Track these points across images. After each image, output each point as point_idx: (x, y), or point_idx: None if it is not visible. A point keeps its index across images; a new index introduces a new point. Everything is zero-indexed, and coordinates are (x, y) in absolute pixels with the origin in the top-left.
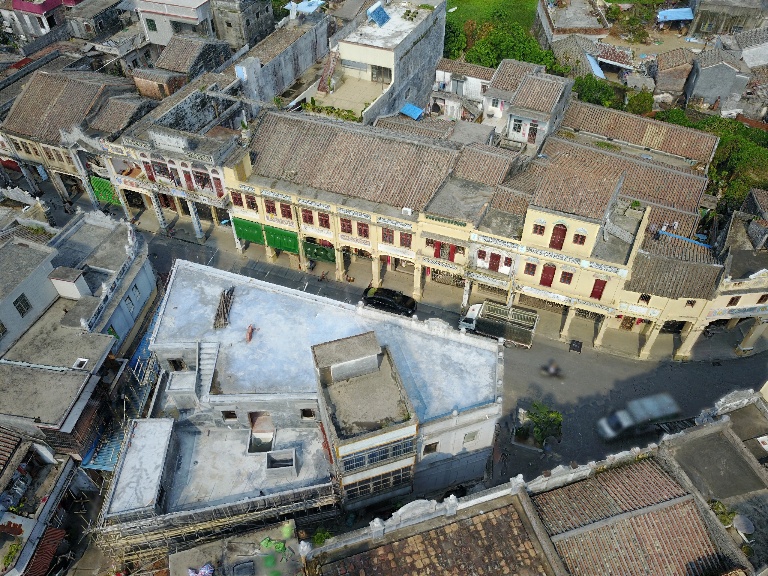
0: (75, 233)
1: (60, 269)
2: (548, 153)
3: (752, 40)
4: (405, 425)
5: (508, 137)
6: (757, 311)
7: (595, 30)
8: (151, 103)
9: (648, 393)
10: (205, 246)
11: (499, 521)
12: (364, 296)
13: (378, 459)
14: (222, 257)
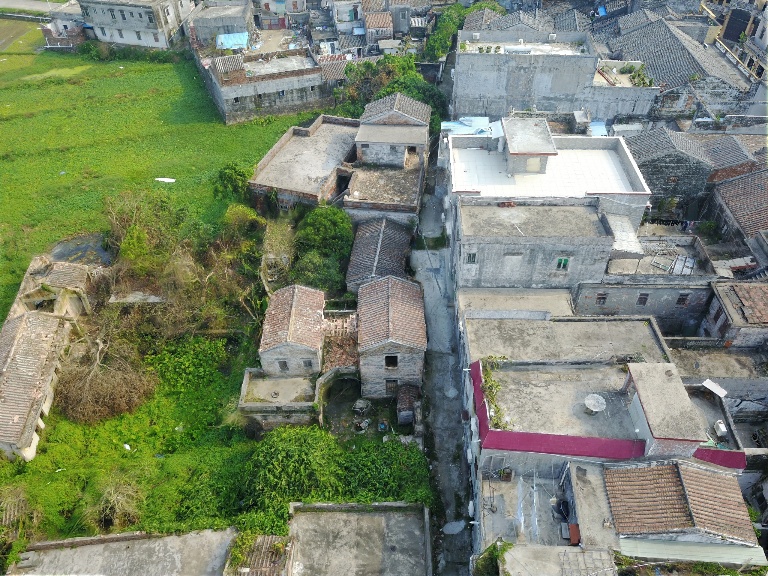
0: None
1: None
2: None
3: None
4: None
5: None
6: None
7: None
8: (763, 150)
9: None
10: None
11: None
12: None
13: None
14: None
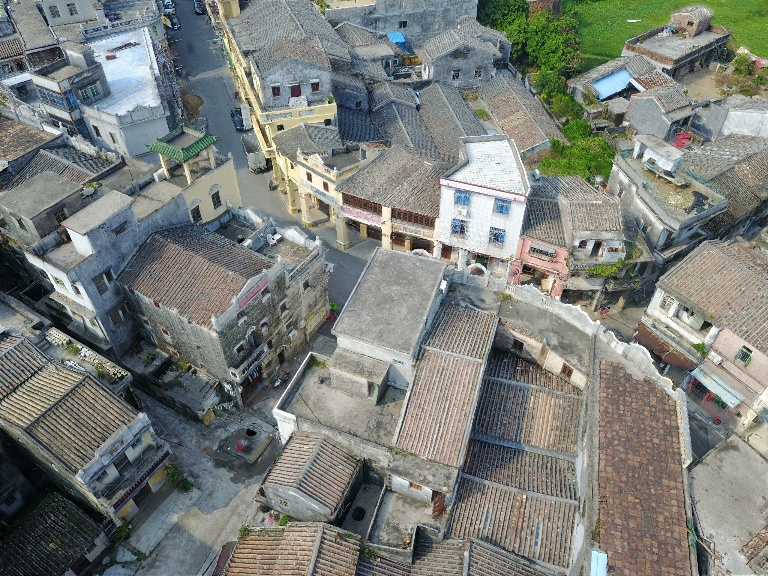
0: (143, 5)
1: (99, 4)
2: (424, 93)
3: (750, 105)
4: (53, 80)
5: (422, 75)
6: (328, 199)
7: (661, 58)
8: None
9: None
10: (225, 61)
11: (45, 139)
12: (232, 109)
13: (52, 101)
14: (223, 69)
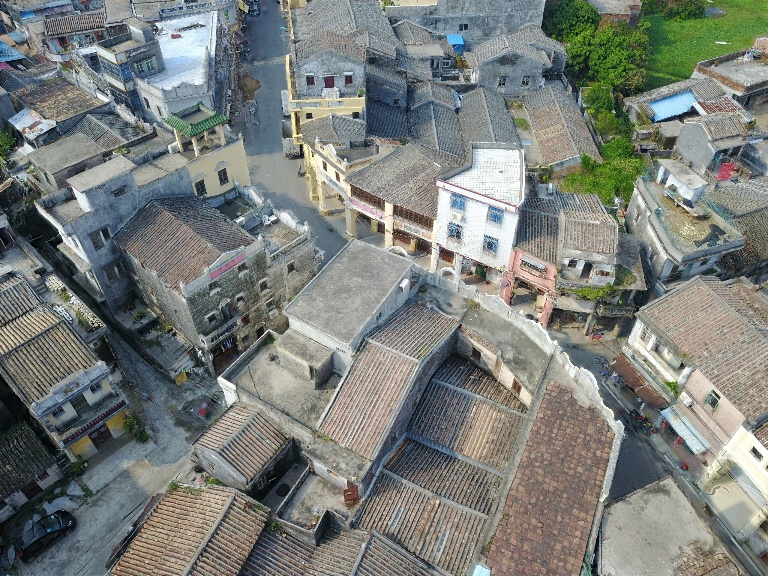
0: None
1: None
2: (468, 97)
3: None
4: (111, 52)
5: None
6: (339, 189)
7: (733, 83)
8: None
9: (282, 206)
10: None
11: (95, 105)
12: None
13: None
14: None
